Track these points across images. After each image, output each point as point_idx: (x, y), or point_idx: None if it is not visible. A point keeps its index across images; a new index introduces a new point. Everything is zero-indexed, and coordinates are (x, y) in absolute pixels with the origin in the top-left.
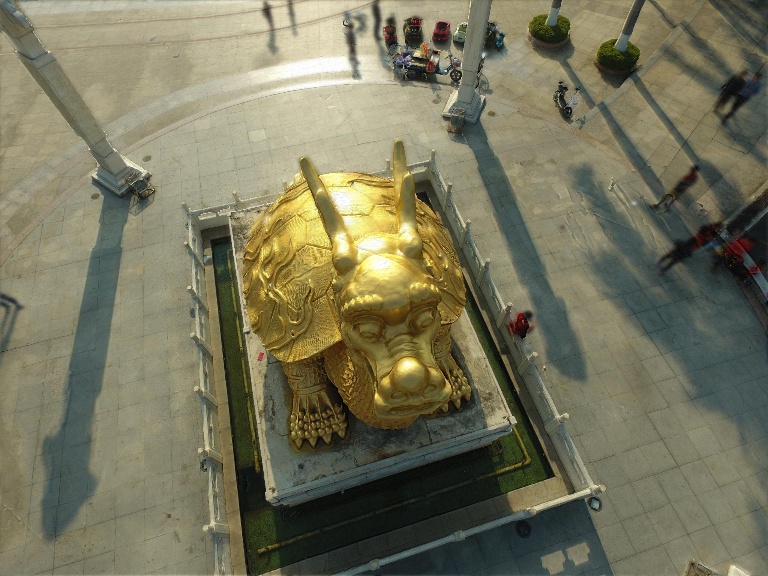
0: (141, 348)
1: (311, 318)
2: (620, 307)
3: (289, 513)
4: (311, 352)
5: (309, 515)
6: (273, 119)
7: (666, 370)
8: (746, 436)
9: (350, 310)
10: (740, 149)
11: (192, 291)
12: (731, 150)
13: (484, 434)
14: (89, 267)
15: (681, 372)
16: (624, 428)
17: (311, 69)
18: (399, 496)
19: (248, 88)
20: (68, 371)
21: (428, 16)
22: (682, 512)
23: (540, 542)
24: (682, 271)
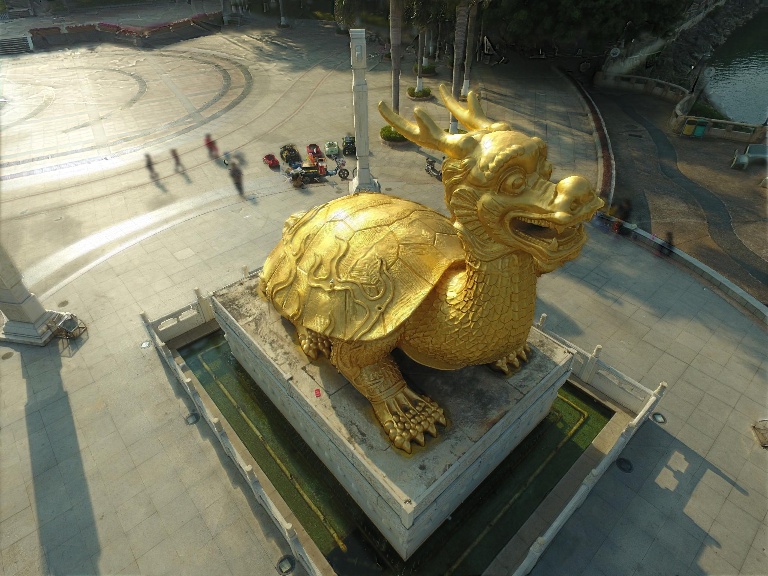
0: (138, 481)
1: (393, 284)
2: (569, 278)
3: (408, 568)
4: (409, 311)
5: (427, 564)
6: (194, 238)
7: (630, 306)
8: (711, 327)
9: (499, 163)
10: (569, 169)
11: (192, 384)
12: (564, 171)
13: (556, 375)
14: (27, 425)
15: (640, 304)
16: (635, 355)
17: (210, 198)
18: (502, 499)
19: (152, 225)
20: (40, 549)
21: (296, 145)
22: (717, 395)
23: (645, 469)
24: (590, 244)
